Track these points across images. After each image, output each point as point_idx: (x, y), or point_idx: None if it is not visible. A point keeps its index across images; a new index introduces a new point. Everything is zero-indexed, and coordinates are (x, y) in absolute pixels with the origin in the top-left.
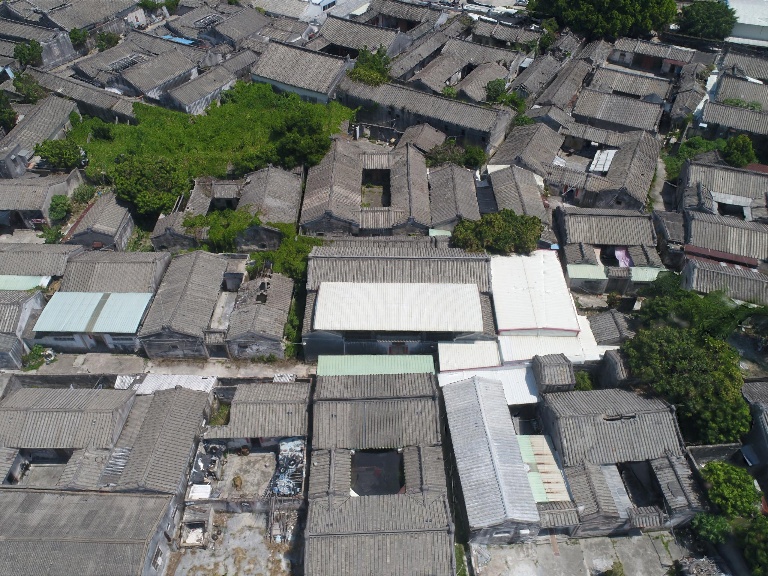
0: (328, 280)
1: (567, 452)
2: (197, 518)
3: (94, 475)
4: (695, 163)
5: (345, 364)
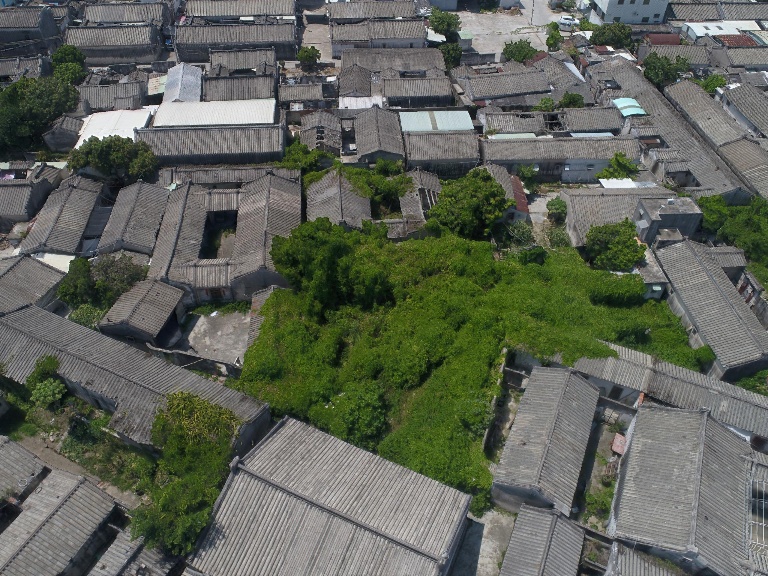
0: None
1: None
2: None
3: None
4: None
5: None
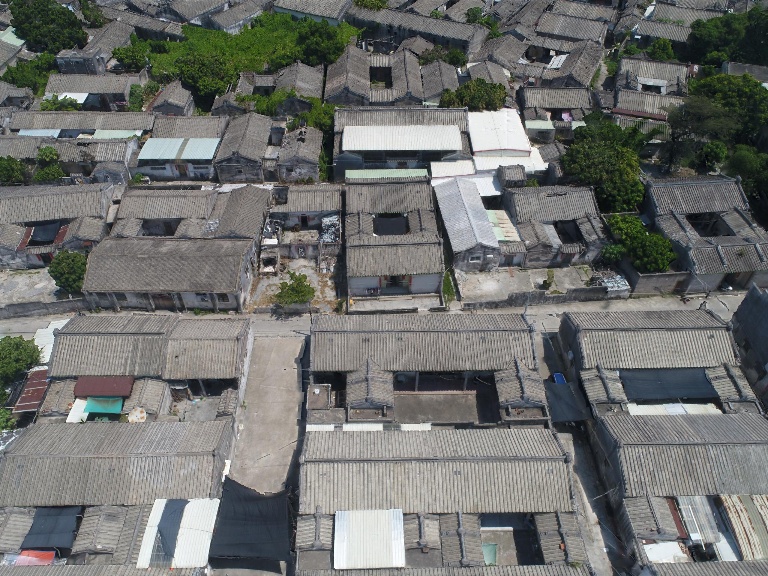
0: (350, 125)
1: (519, 214)
2: (270, 256)
3: (198, 231)
4: (626, 57)
5: (365, 173)
